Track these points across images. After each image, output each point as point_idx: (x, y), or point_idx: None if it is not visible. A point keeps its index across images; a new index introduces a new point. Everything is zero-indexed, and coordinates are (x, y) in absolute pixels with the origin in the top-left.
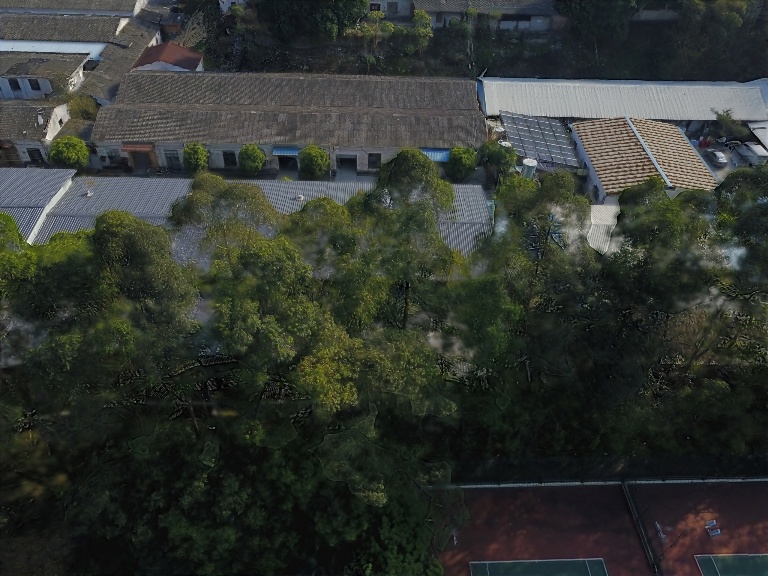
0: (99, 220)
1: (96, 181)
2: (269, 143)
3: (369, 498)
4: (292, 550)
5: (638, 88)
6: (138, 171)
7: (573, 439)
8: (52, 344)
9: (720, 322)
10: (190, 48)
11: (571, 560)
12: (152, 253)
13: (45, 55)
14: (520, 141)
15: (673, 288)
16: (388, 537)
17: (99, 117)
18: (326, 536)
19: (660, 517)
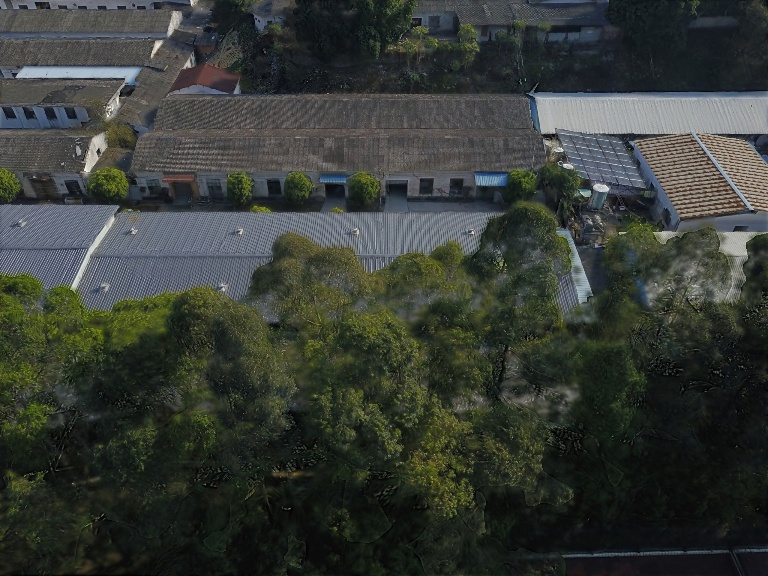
0: (179, 300)
1: (139, 217)
2: (316, 170)
3: None
4: None
5: (701, 101)
6: (179, 201)
7: (675, 504)
8: (124, 440)
9: None
10: (226, 69)
11: None
12: (244, 342)
13: (81, 82)
14: (581, 162)
15: None
16: None
17: (138, 146)
18: None
19: None
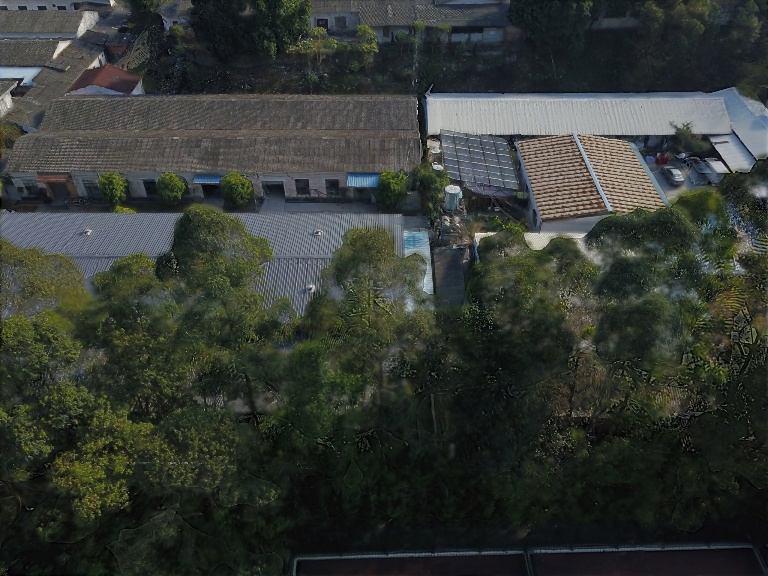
0: None
1: None
2: (189, 171)
3: None
4: None
5: (592, 102)
6: (58, 202)
7: (467, 505)
8: None
9: (610, 382)
10: (133, 69)
11: None
12: None
13: None
14: (457, 163)
15: (519, 358)
16: None
17: (16, 147)
18: None
19: None
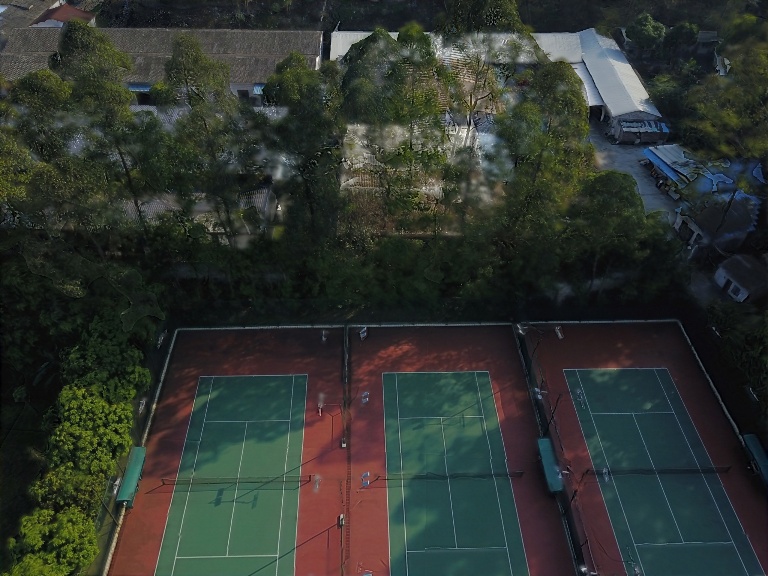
0: None
1: None
2: (125, 81)
3: (67, 290)
4: (34, 347)
5: None
6: None
7: (302, 289)
8: None
9: None
10: (89, 11)
11: (282, 375)
12: None
13: None
14: None
15: (286, 128)
16: (94, 328)
17: None
18: None
19: (367, 349)
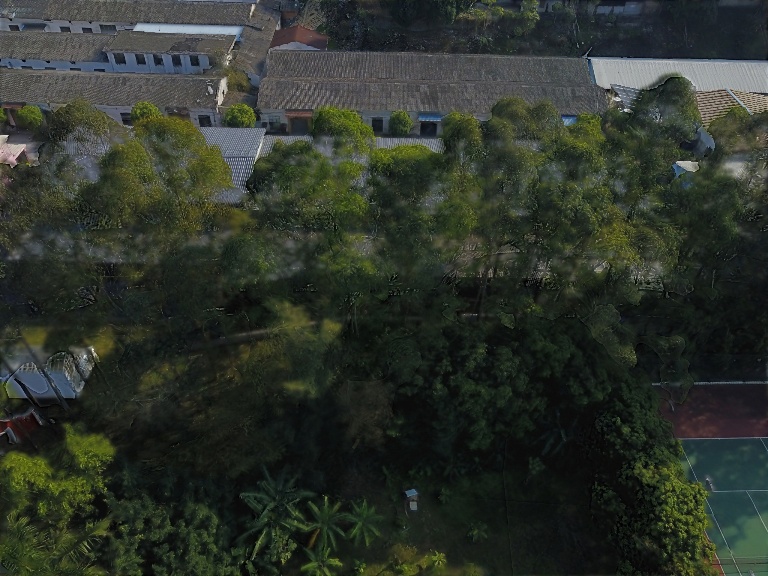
0: (464, 123)
1: (283, 139)
2: (415, 110)
3: (626, 359)
4: (541, 414)
5: (731, 65)
6: None
7: (738, 344)
8: (418, 221)
9: None
10: None
11: (748, 438)
12: (517, 145)
13: (198, 35)
14: None
15: None
16: (630, 397)
17: (262, 88)
18: (578, 397)
19: None
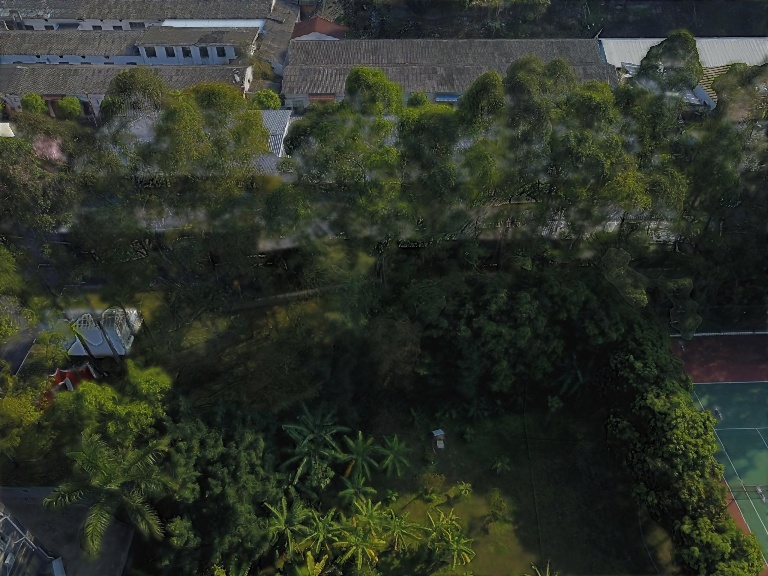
0: (482, 77)
1: None
2: (432, 91)
3: (637, 299)
4: (558, 356)
5: (740, 41)
6: None
7: (747, 295)
8: (441, 169)
9: None
10: None
11: (758, 382)
12: (531, 94)
13: (223, 28)
14: None
15: None
16: (642, 337)
17: (286, 74)
18: (593, 338)
19: None
